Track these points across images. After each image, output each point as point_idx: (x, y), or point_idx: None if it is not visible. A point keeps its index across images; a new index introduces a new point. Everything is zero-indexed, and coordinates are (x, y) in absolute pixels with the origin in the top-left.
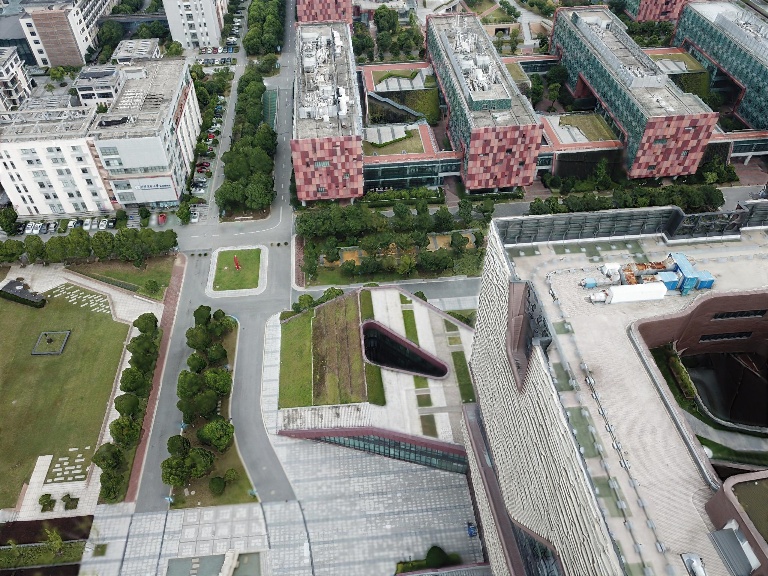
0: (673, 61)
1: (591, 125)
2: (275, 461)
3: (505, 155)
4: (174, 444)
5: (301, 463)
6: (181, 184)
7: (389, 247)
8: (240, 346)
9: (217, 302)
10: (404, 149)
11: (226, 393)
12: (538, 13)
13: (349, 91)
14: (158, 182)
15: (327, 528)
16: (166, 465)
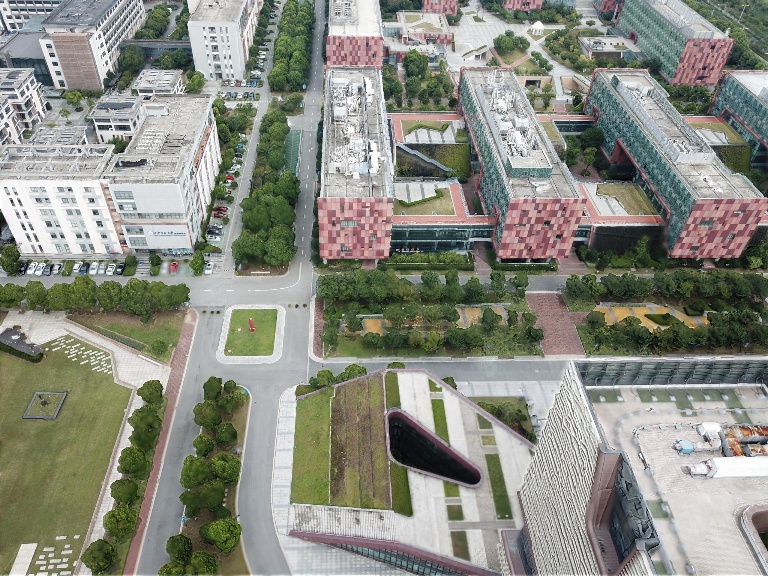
0: (713, 131)
1: (630, 197)
2: (284, 568)
3: (543, 227)
4: (174, 546)
5: (313, 573)
6: (196, 231)
7: (415, 319)
8: (251, 423)
9: (228, 369)
10: (434, 210)
11: (234, 482)
12: (570, 67)
13: (380, 145)
14: (173, 229)
15: None
16: (164, 573)
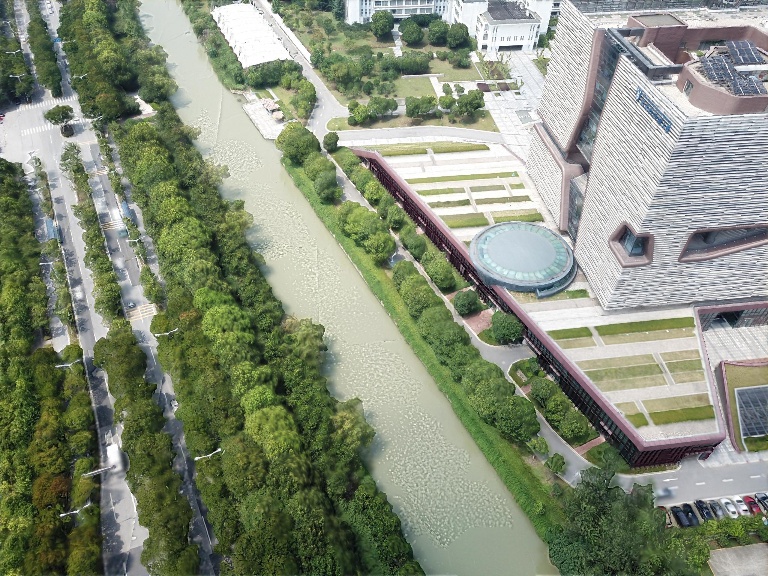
0: None
1: None
2: None
3: None
4: None
5: None
6: None
7: None
8: None
9: None
10: None
11: None
12: None
13: None
14: None
15: None
16: None
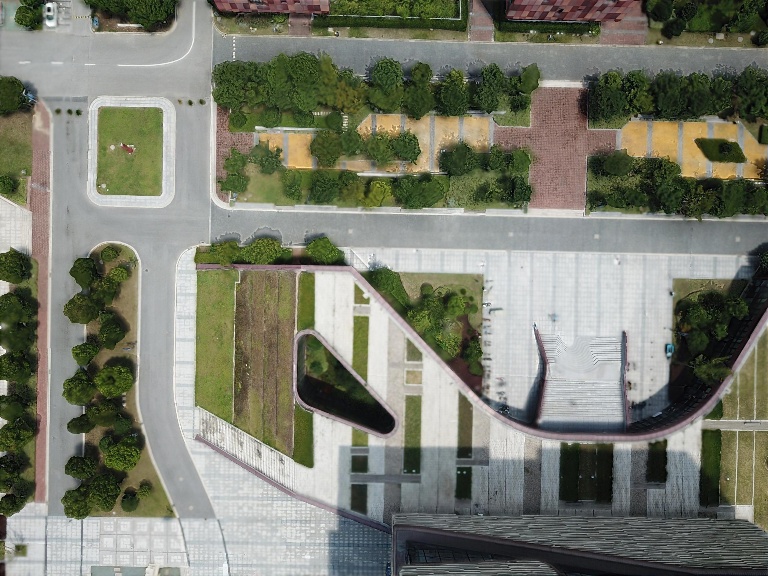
0: None
1: None
2: (193, 472)
3: None
4: (72, 475)
5: (221, 478)
6: None
7: None
8: (144, 302)
9: (106, 215)
10: None
11: None
12: None
13: None
14: None
15: (246, 552)
16: (66, 506)
